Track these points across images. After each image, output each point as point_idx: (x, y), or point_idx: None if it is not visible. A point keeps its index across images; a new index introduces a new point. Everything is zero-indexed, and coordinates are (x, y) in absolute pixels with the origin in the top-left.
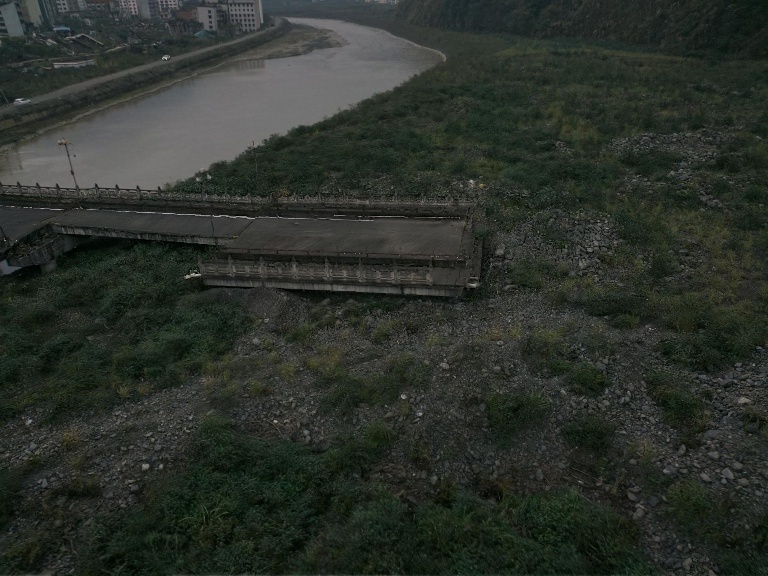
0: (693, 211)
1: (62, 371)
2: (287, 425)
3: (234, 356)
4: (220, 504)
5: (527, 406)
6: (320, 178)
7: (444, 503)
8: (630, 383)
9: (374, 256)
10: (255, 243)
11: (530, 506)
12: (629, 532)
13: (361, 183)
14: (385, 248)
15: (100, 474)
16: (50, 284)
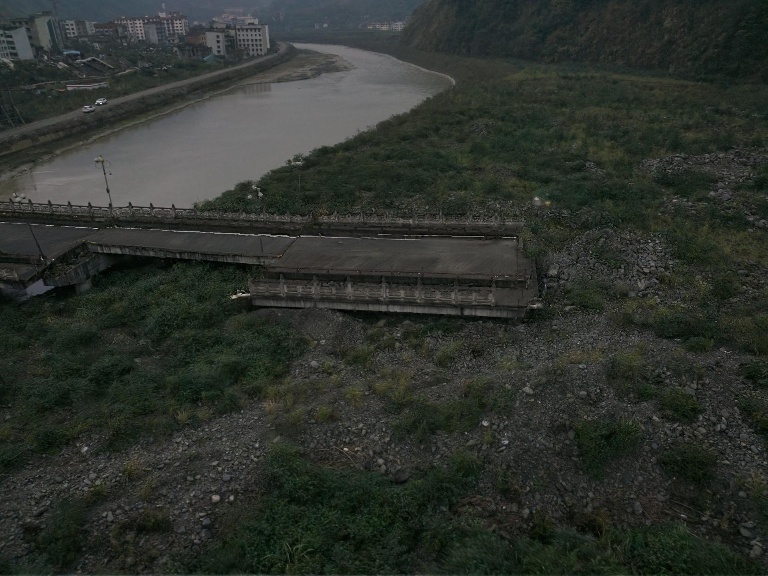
0: (741, 231)
1: (114, 395)
2: (359, 453)
3: (292, 379)
4: (303, 540)
5: (619, 434)
6: (352, 198)
7: (542, 539)
8: (724, 409)
9: (430, 276)
10: (301, 262)
11: (636, 543)
12: (748, 572)
13: (394, 203)
14: (439, 268)
15: (168, 506)
16: (88, 304)
